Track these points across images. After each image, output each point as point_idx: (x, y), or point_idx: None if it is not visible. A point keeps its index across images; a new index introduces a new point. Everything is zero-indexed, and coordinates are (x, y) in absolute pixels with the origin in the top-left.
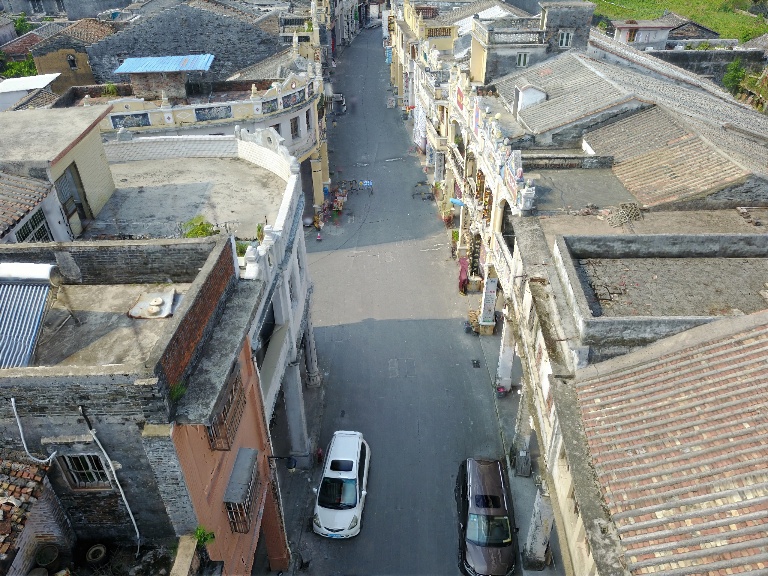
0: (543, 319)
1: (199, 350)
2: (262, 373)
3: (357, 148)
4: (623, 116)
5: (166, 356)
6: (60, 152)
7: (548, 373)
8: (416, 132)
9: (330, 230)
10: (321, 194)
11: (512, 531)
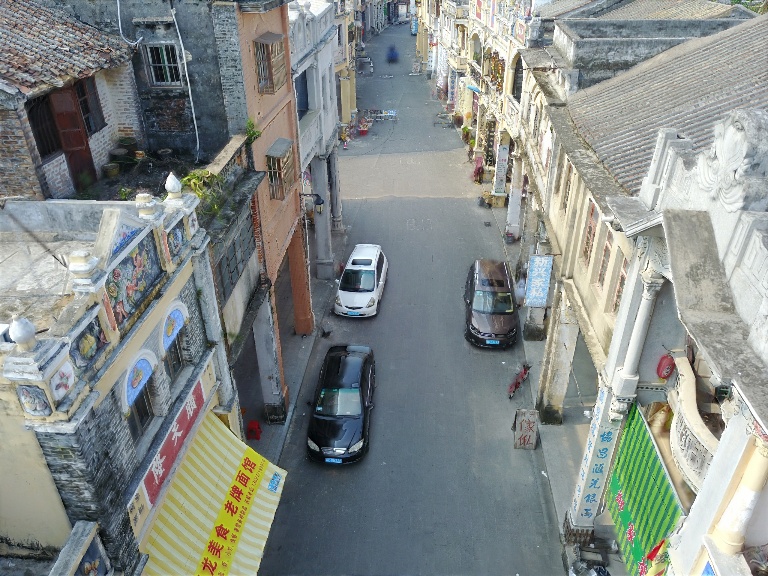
0: (542, 84)
1: None
2: None
3: (383, 96)
4: (626, 2)
5: None
6: None
7: (547, 138)
8: (439, 76)
9: (356, 144)
10: (349, 113)
11: (514, 305)
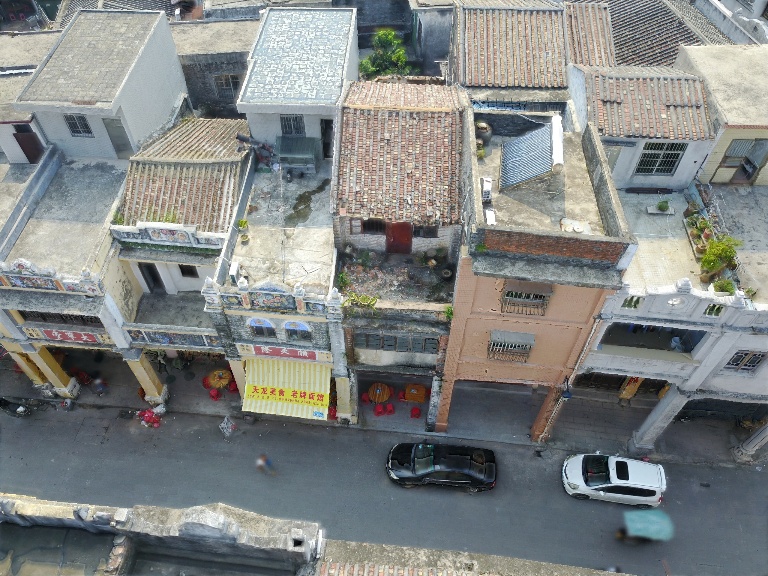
0: None
1: (529, 257)
2: (624, 348)
3: None
4: None
5: (493, 232)
6: (748, 124)
7: None
8: None
9: None
10: None
11: None
